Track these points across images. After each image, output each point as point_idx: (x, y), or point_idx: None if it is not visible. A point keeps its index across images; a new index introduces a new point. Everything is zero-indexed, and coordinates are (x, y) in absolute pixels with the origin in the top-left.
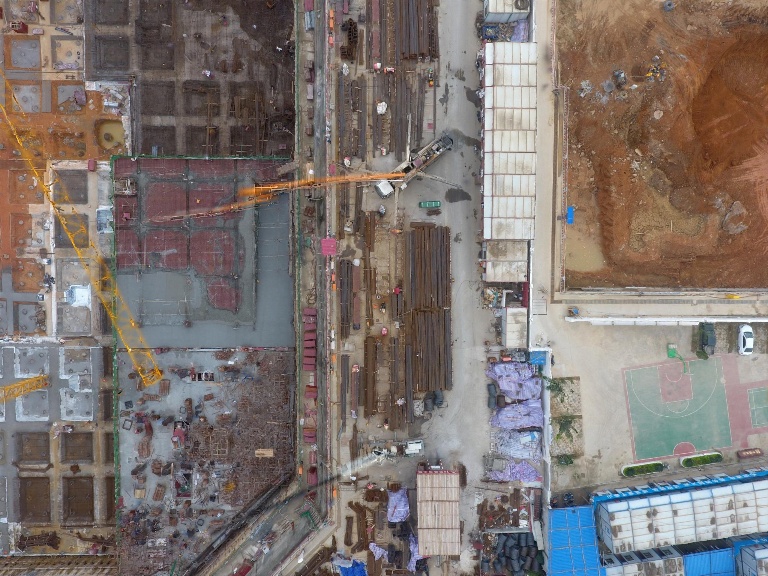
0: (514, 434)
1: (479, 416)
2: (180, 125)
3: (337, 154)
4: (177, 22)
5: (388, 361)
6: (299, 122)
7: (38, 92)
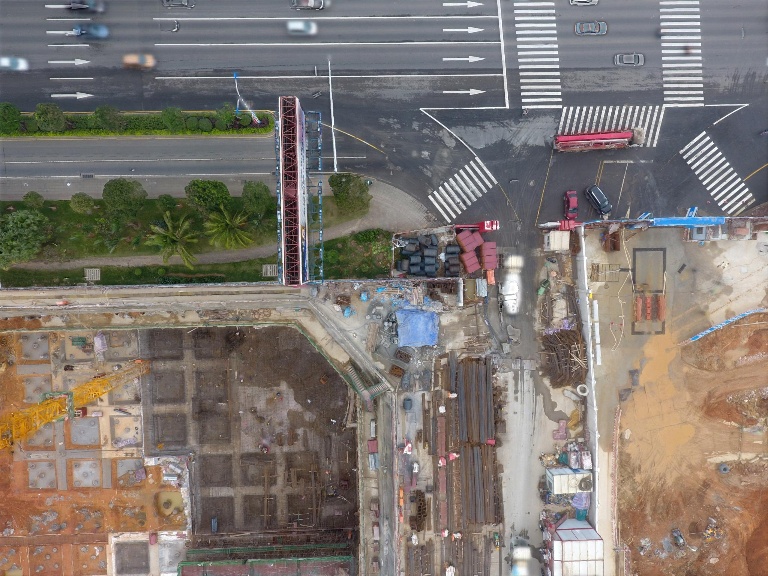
0: None
1: None
2: (238, 495)
3: None
4: (233, 398)
5: None
6: (365, 554)
7: (98, 467)
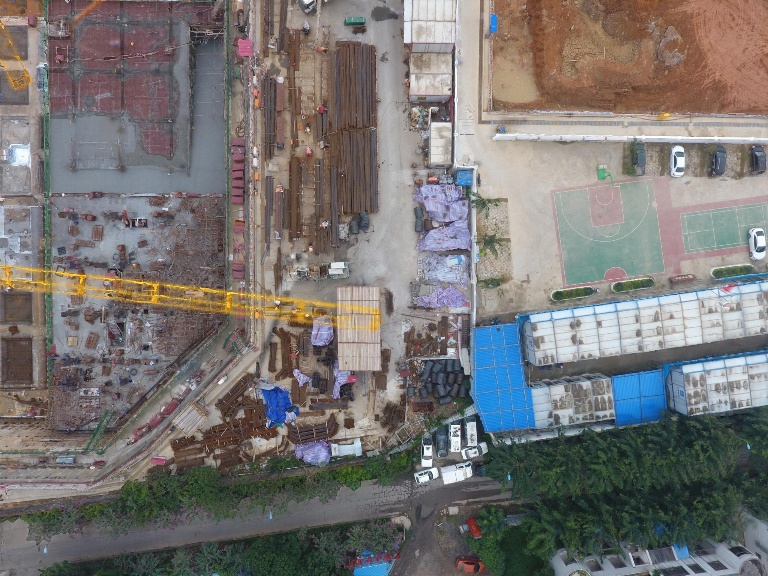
0: (441, 259)
1: (406, 241)
2: None
3: None
4: None
5: (313, 183)
6: None
7: None
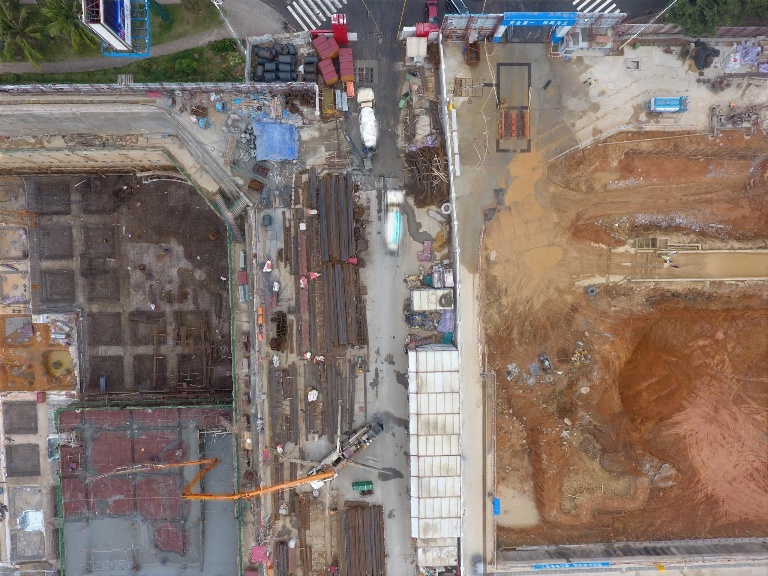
0: None
1: None
2: (127, 354)
3: (270, 439)
4: (121, 255)
5: None
6: (236, 390)
7: None
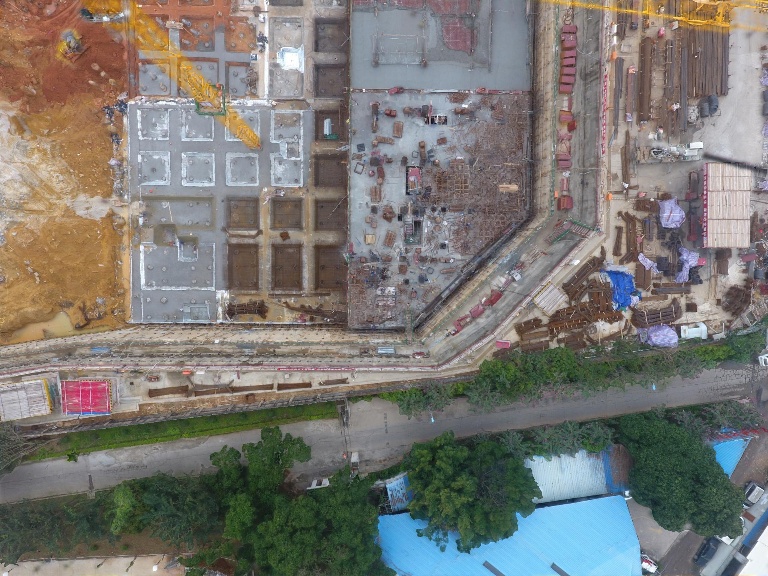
0: None
1: (752, 126)
2: None
3: None
4: None
5: (663, 65)
6: None
7: None
